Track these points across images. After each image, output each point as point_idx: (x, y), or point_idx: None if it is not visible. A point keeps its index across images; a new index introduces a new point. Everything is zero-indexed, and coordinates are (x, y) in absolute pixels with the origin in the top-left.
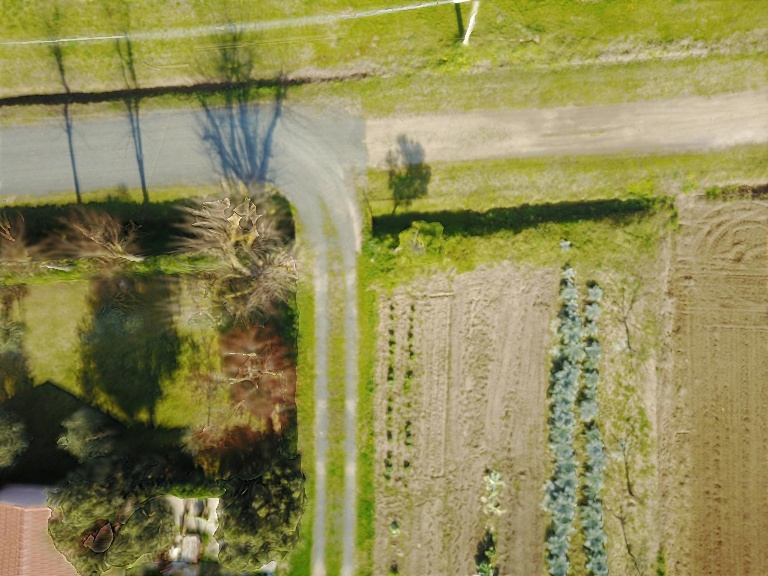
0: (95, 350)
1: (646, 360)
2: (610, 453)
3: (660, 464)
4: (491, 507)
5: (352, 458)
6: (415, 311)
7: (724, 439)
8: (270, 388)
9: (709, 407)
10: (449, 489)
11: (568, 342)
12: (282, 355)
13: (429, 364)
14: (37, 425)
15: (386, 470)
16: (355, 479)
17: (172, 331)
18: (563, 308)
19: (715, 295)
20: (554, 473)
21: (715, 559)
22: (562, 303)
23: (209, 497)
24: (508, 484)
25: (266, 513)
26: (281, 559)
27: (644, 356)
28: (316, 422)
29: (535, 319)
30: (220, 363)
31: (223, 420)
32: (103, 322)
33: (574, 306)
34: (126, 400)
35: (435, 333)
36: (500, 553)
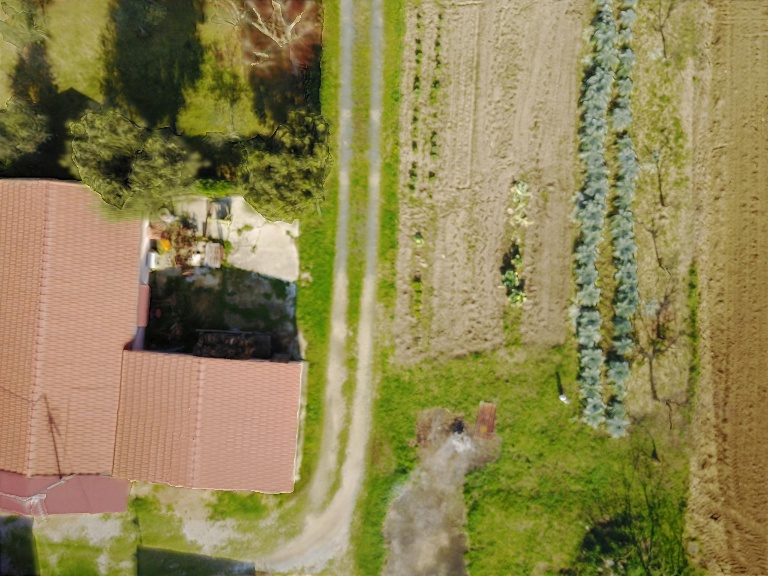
0: (119, 57)
1: (683, 70)
2: (643, 165)
3: (695, 177)
4: (518, 218)
5: (376, 168)
6: (442, 19)
7: (763, 150)
8: (294, 96)
9: (748, 118)
10: (475, 200)
11: (601, 48)
12: (306, 46)
13: (456, 74)
14: (62, 128)
15: (411, 179)
16: (379, 189)
17: (195, 39)
18: (596, 16)
19: (758, 3)
20: (584, 184)
21: (750, 273)
22: (596, 11)
23: (232, 190)
24: (536, 196)
25: (290, 140)
26: (305, 201)
27: (681, 66)
28: (340, 132)
29: (567, 28)
30: (243, 71)
31: (246, 128)
32: (126, 9)
33: (608, 12)
34: (149, 108)
35: (463, 42)
36: (526, 265)
